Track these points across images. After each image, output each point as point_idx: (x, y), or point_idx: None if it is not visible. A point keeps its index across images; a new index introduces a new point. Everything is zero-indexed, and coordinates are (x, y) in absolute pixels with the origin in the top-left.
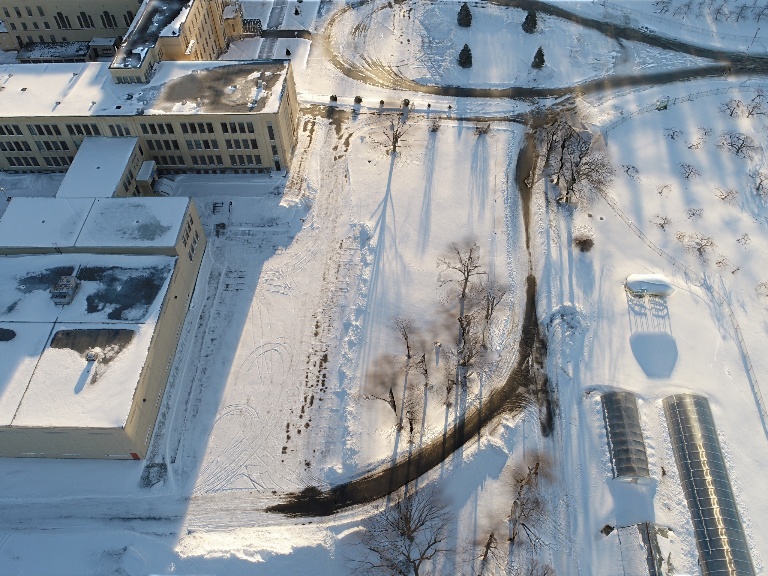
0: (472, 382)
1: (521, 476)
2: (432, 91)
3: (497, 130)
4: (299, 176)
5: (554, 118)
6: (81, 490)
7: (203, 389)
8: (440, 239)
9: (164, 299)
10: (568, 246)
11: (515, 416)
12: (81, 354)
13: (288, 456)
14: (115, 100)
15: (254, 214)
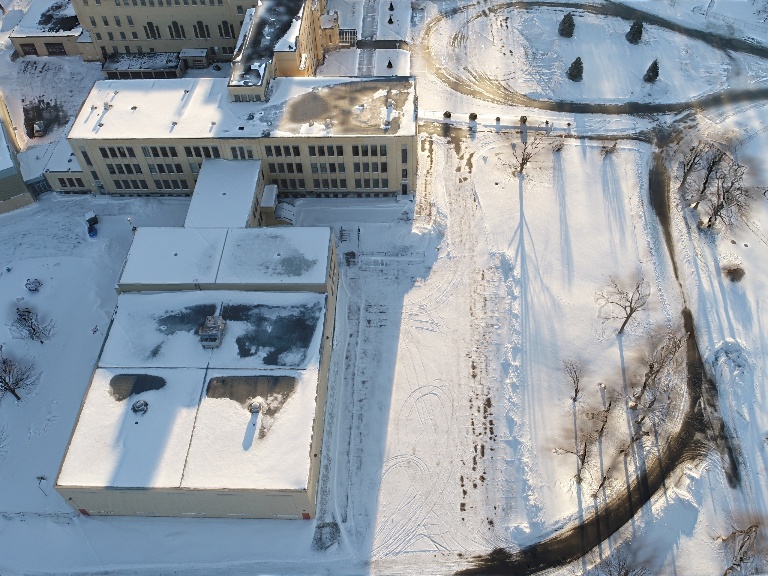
0: (646, 428)
1: (716, 533)
2: (546, 107)
3: (622, 149)
4: (427, 200)
5: (678, 136)
6: (249, 554)
7: (363, 438)
8: (585, 269)
9: (322, 342)
10: (717, 276)
11: (698, 465)
12: (242, 404)
13: (468, 514)
14: (236, 120)
15: (385, 242)
